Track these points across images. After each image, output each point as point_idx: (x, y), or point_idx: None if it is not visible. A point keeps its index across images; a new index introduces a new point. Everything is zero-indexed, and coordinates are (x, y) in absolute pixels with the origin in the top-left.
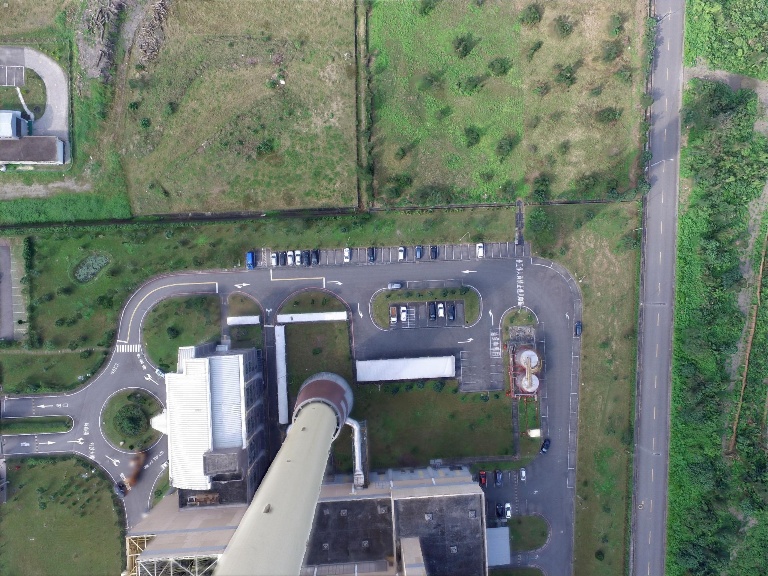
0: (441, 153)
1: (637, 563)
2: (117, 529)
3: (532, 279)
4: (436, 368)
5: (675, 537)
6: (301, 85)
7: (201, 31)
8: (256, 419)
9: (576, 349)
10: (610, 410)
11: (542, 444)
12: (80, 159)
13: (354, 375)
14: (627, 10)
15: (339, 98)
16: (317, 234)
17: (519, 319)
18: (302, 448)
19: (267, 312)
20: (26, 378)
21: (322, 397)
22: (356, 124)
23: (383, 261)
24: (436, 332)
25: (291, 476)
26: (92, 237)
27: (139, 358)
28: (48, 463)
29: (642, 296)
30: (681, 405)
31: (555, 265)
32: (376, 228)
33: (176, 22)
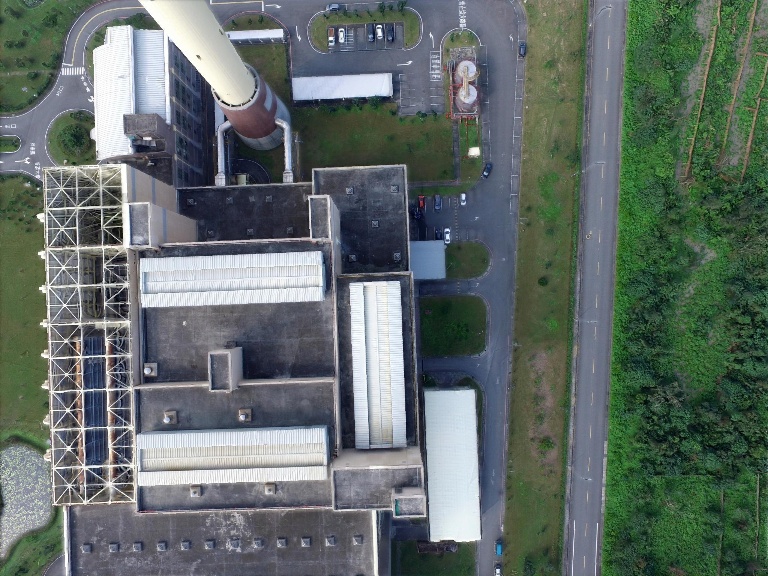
0: None
1: (584, 295)
2: None
3: (474, 0)
4: (373, 85)
5: (625, 267)
6: None
7: None
8: (192, 131)
9: (520, 72)
10: (556, 134)
11: (483, 168)
12: None
13: (292, 98)
14: None
15: None
16: None
17: (460, 41)
18: None
19: None
20: None
21: None
22: None
23: None
24: (375, 55)
25: None
26: None
27: (83, 80)
28: None
29: (591, 18)
30: (632, 130)
31: None
32: None
33: None
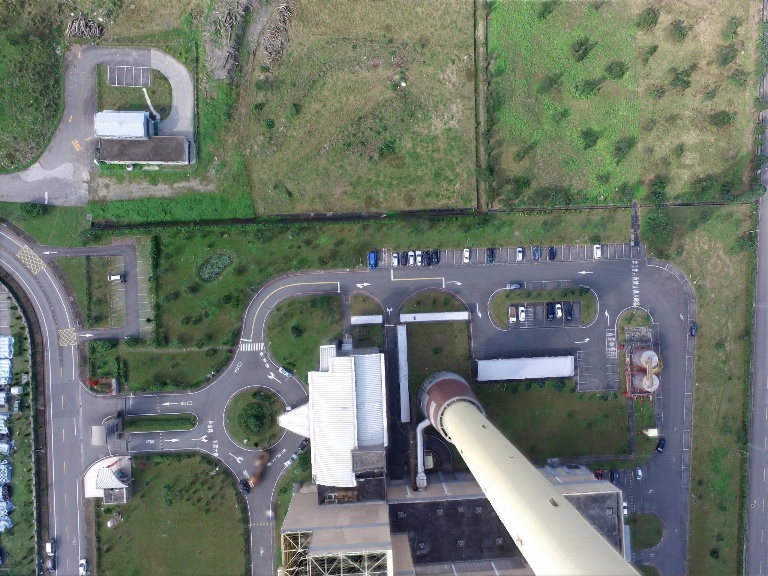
0: (558, 155)
1: (749, 561)
2: (240, 526)
3: (647, 280)
4: (556, 368)
5: None
6: (421, 87)
7: (324, 33)
8: None
9: (690, 349)
10: (724, 410)
11: (657, 443)
12: (205, 159)
13: (473, 374)
14: (740, 15)
15: (459, 100)
16: None
17: (635, 320)
18: (506, 445)
19: (388, 312)
20: (152, 376)
21: (466, 396)
22: (475, 126)
23: (501, 262)
24: (553, 332)
25: (532, 472)
26: (218, 237)
27: (262, 357)
28: (173, 460)
29: (754, 297)
30: None
31: (670, 266)
32: None
33: (300, 24)
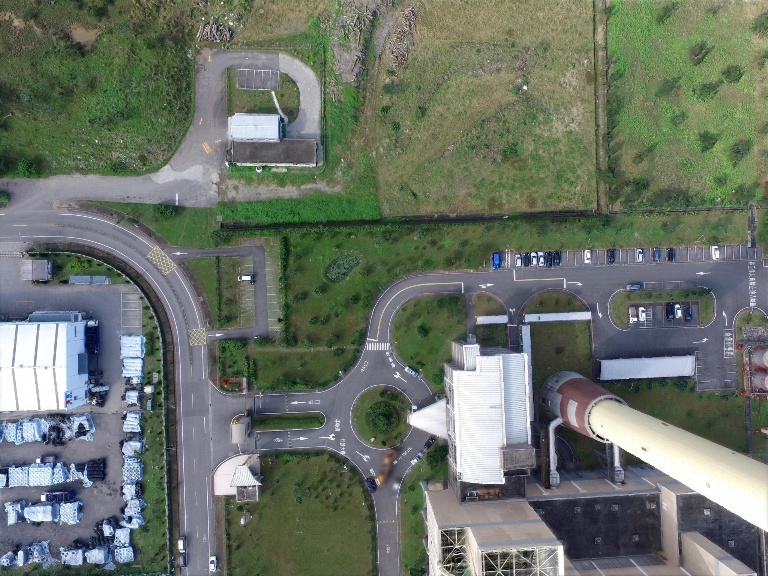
0: (676, 158)
1: None
2: (367, 523)
3: (764, 281)
4: (677, 367)
5: None
6: (543, 91)
7: (448, 37)
8: None
9: None
10: None
11: None
12: (332, 161)
13: (594, 374)
14: None
15: (579, 103)
16: (559, 236)
17: (752, 320)
18: None
19: (510, 312)
20: (281, 375)
21: (612, 394)
22: (595, 129)
23: (621, 262)
24: (672, 332)
25: None
26: (346, 238)
27: (388, 356)
28: (302, 458)
29: None
30: None
31: None
32: (620, 230)
33: (424, 29)
